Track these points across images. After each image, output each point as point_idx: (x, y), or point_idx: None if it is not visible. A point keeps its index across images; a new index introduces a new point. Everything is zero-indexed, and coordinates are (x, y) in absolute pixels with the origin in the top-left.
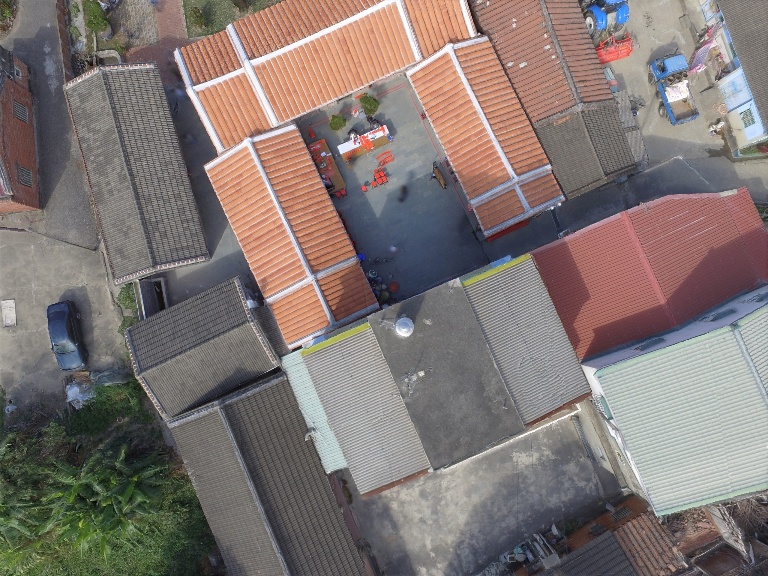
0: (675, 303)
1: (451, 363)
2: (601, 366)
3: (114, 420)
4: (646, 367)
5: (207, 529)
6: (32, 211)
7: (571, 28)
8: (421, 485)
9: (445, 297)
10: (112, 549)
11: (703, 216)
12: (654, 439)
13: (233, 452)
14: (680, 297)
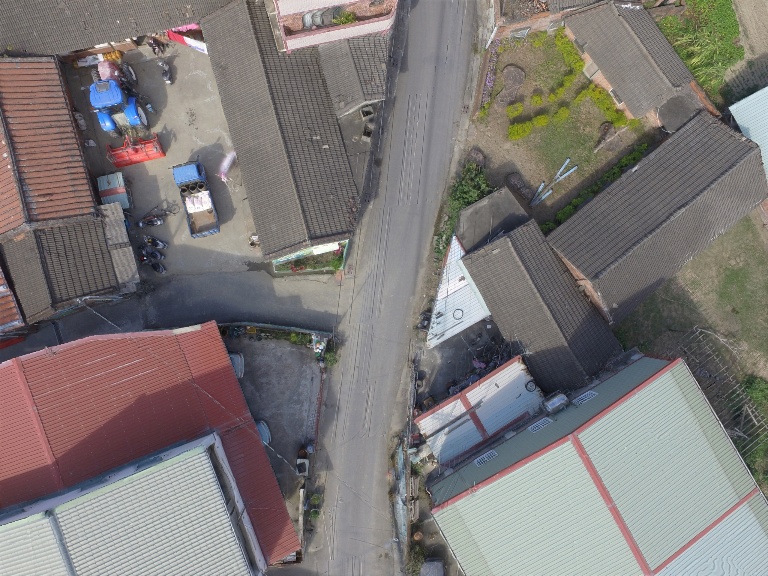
0: (69, 462)
1: None
2: None
3: None
4: None
5: None
6: None
7: (45, 133)
8: None
9: None
10: None
11: (139, 358)
12: None
13: None
14: (78, 455)
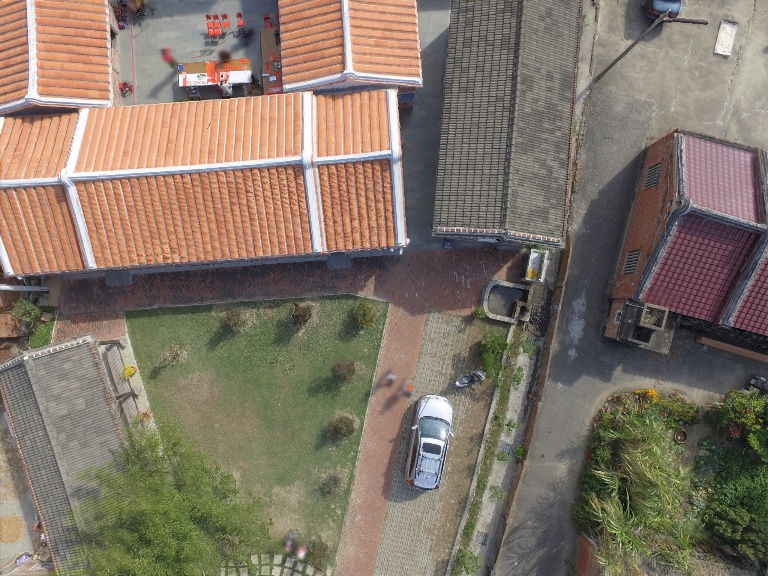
0: None
1: None
2: None
3: None
4: None
5: None
6: None
7: None
8: None
9: None
10: None
11: None
12: None
13: None
14: None
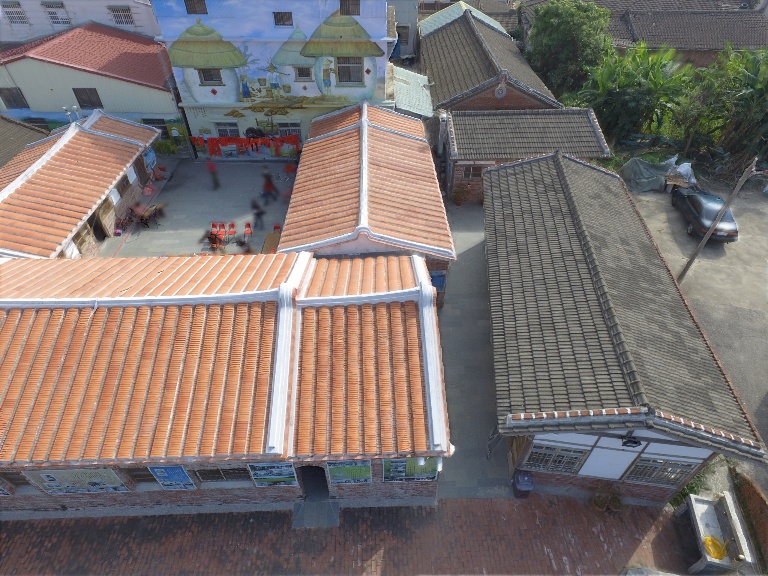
0: None
1: None
2: None
3: None
4: None
5: None
6: None
7: None
8: None
9: None
10: None
11: None
12: None
13: None
14: None
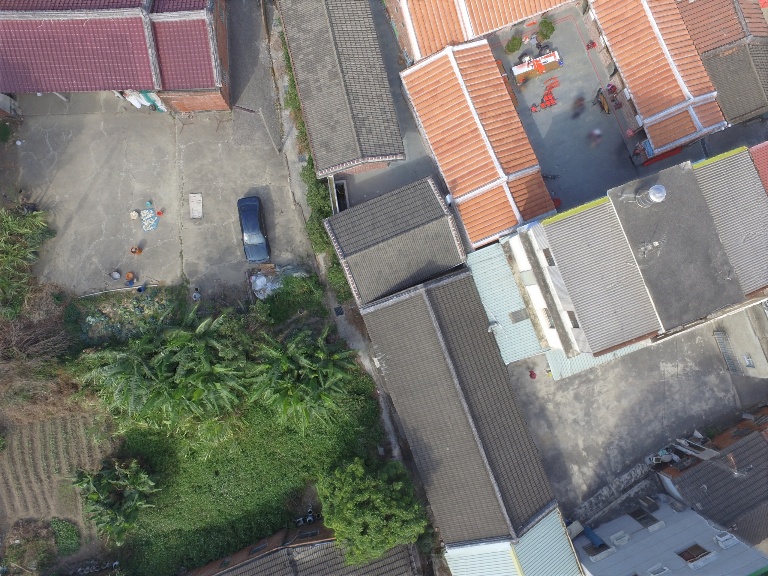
0: None
1: (682, 236)
2: None
3: (294, 312)
4: None
5: (378, 419)
6: (221, 111)
7: None
8: (575, 388)
9: (677, 177)
10: (290, 433)
11: None
12: None
13: (432, 334)
14: None
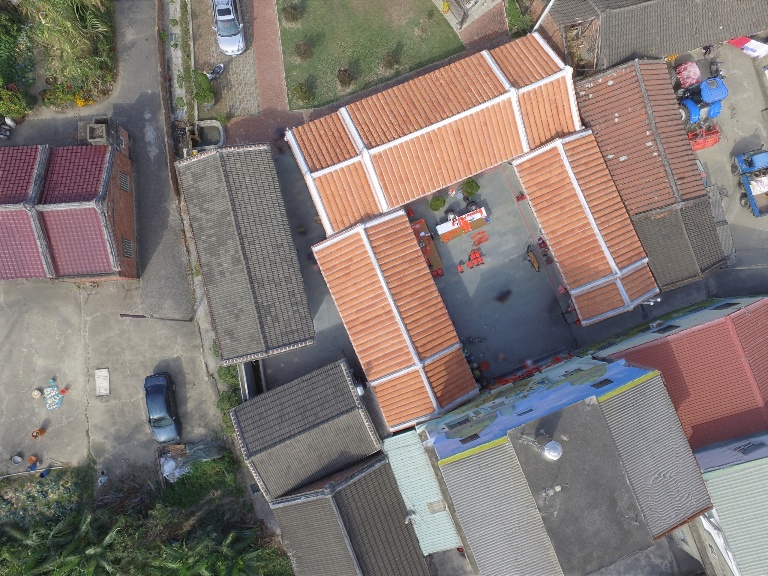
0: None
1: (587, 479)
2: (706, 468)
3: (207, 493)
4: (753, 474)
5: None
6: None
7: (670, 125)
8: None
9: (582, 414)
10: None
11: None
12: (757, 542)
13: (341, 538)
14: None
